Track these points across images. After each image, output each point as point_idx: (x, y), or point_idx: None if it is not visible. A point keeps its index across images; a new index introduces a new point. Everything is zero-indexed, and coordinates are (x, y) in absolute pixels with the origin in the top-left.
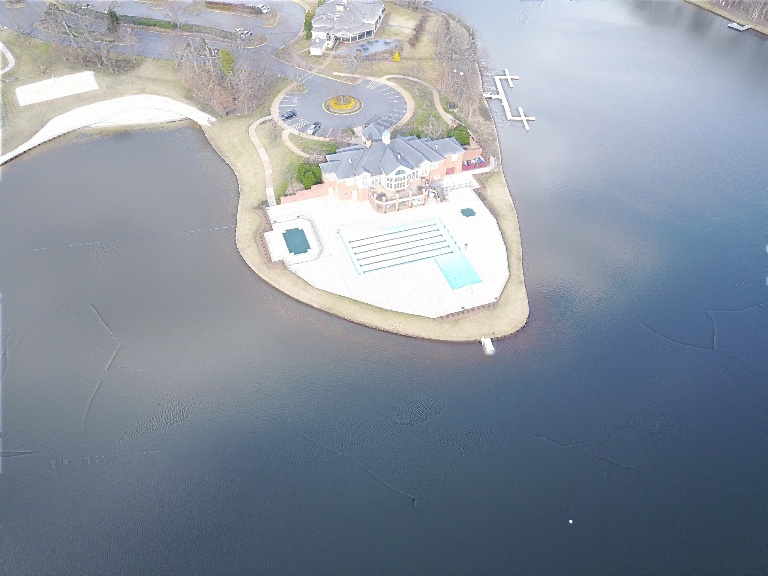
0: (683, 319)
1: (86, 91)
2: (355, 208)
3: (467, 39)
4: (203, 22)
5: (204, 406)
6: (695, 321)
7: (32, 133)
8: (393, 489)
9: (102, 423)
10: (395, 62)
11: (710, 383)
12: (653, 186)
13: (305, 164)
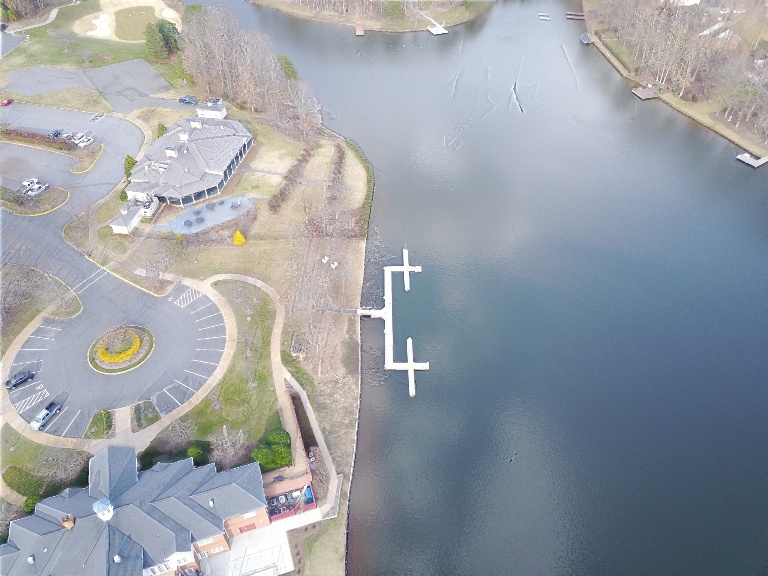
0: None
1: None
2: None
3: (362, 189)
4: None
5: None
6: None
7: None
8: None
9: None
10: (236, 246)
11: None
12: None
13: None
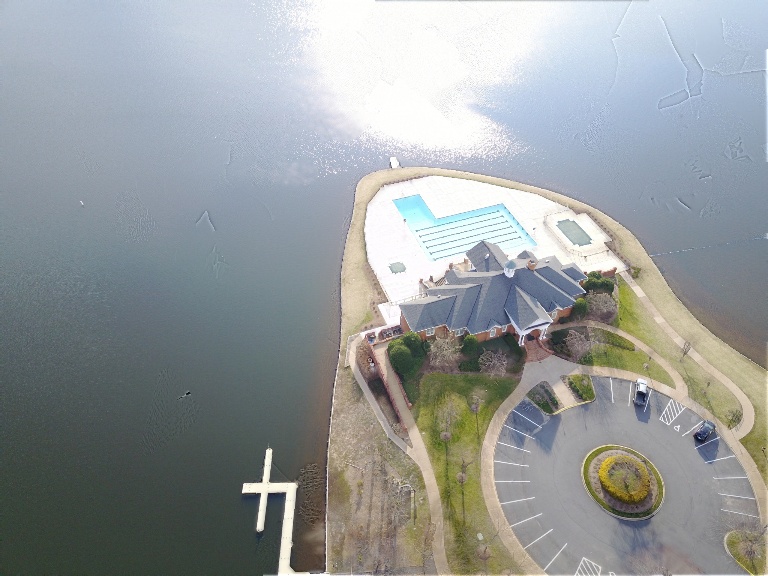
0: None
1: None
2: None
3: None
4: None
5: (577, 138)
6: None
7: None
8: (459, 1)
9: (628, 119)
10: None
11: (276, 92)
12: (177, 264)
13: (606, 281)
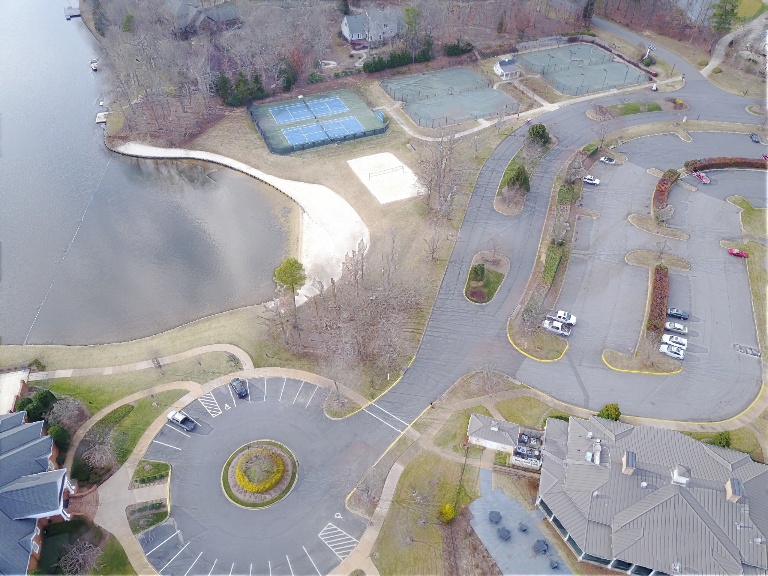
0: None
1: (375, 196)
2: None
3: None
4: (598, 273)
5: None
6: None
7: (295, 178)
8: None
9: None
10: None
11: None
12: None
13: (40, 395)
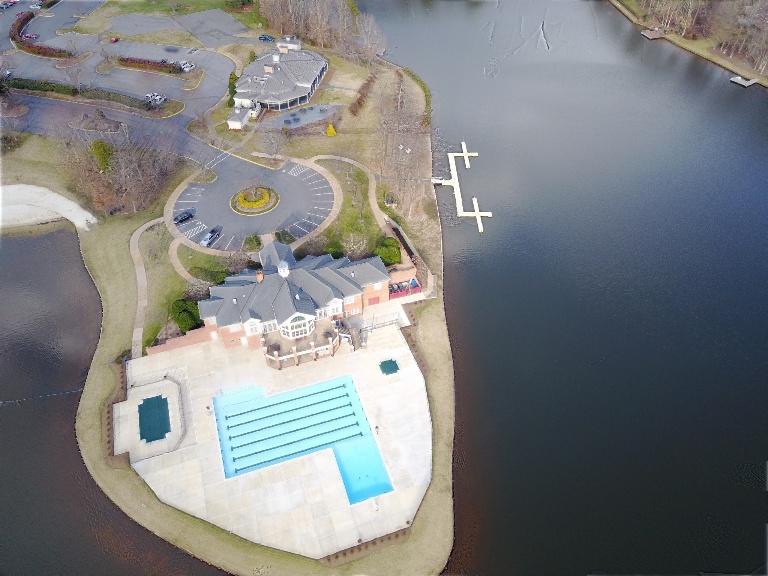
0: (670, 534)
1: None
2: (242, 361)
3: (422, 102)
4: (112, 84)
5: None
6: (687, 535)
7: None
8: None
9: None
10: (329, 137)
11: None
12: None
13: (180, 301)
